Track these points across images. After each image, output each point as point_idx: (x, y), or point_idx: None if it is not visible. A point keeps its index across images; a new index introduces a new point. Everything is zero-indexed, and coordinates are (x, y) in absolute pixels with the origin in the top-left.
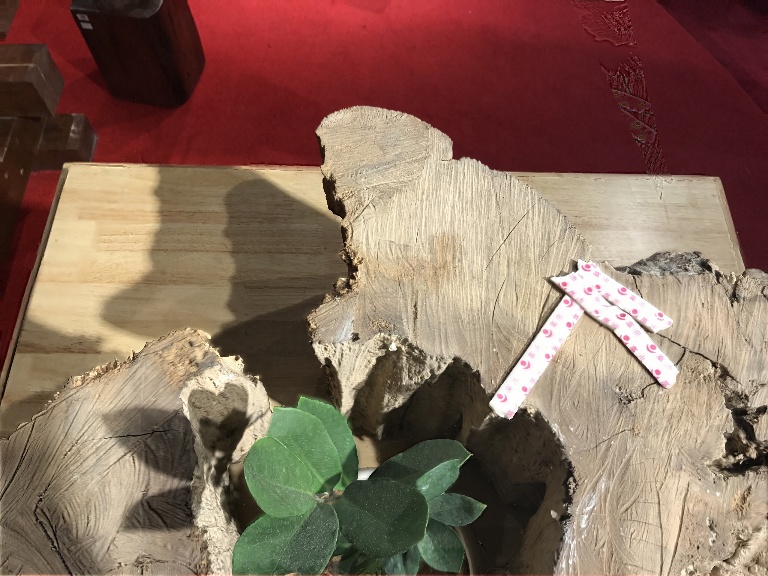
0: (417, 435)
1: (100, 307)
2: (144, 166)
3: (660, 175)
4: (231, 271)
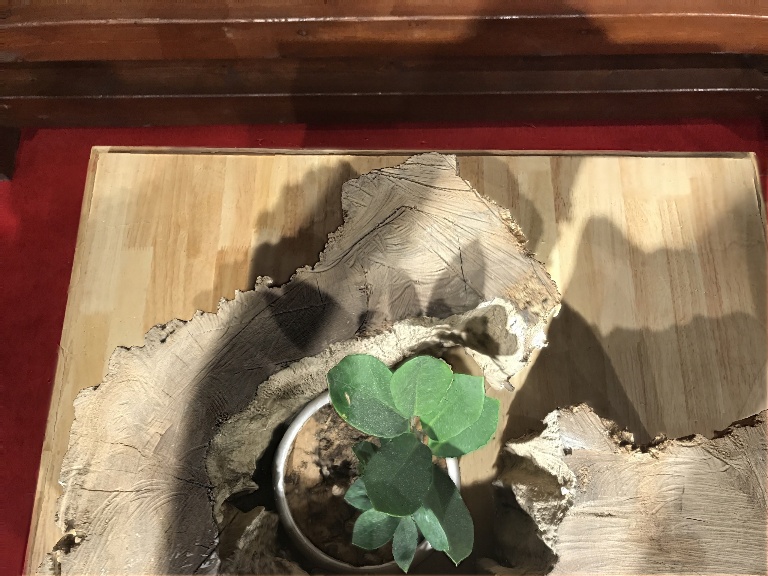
0: (499, 522)
1: (600, 214)
2: (765, 226)
3: None
4: (655, 327)
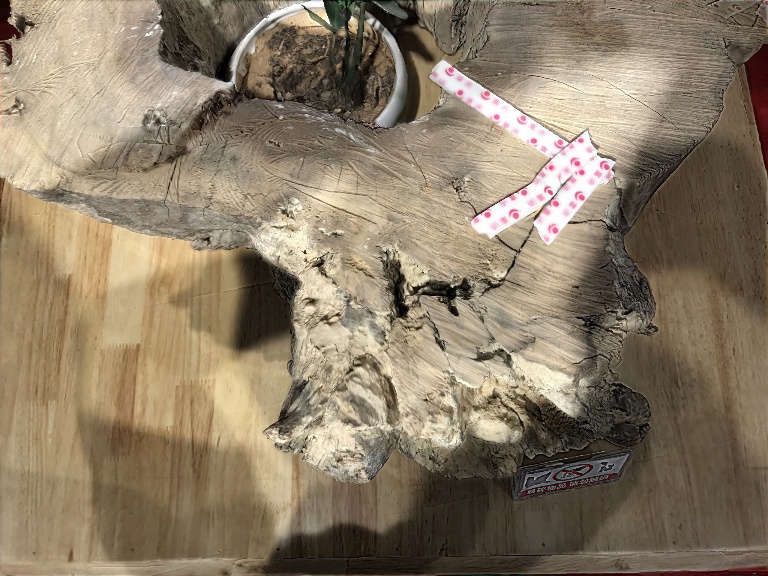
0: None
1: None
2: None
3: (660, 5)
4: None
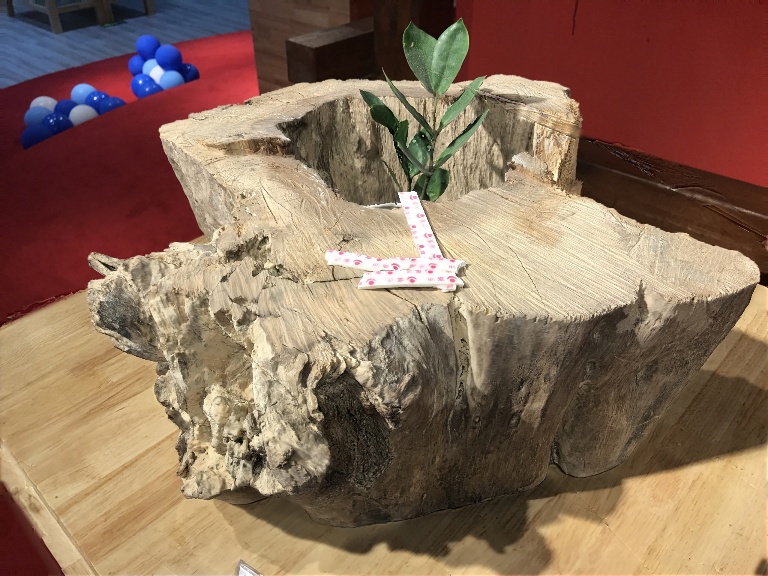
0: None
1: None
2: None
3: None
4: None
